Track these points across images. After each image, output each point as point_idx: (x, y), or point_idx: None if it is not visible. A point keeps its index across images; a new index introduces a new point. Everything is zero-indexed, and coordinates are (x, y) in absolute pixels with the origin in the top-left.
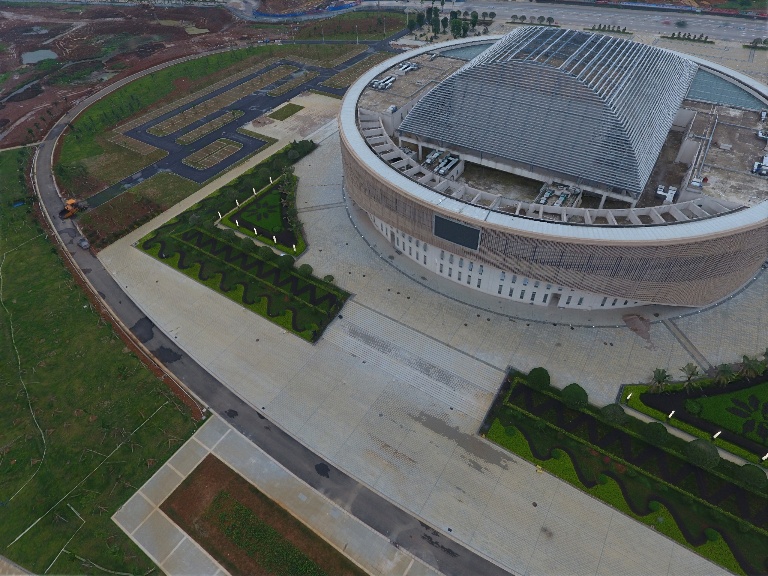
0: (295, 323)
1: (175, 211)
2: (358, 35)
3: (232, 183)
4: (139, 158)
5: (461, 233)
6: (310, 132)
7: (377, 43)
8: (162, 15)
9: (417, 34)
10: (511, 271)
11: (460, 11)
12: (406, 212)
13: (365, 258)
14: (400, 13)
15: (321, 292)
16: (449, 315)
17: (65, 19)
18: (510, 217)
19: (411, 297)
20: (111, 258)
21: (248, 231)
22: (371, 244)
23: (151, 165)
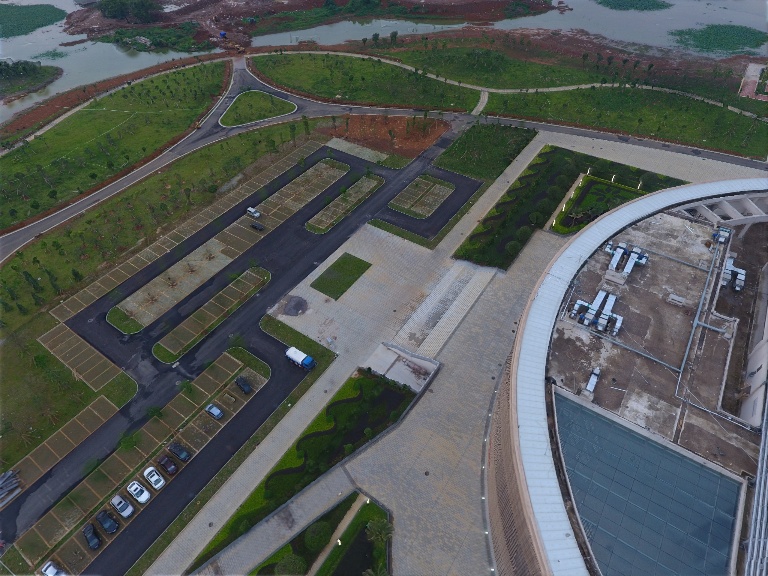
0: None
1: None
2: None
3: None
4: None
5: None
6: None
7: None
8: None
9: None
10: None
11: None
12: None
13: None
14: None
15: None
16: None
17: None
18: None
19: None
20: None
21: None
22: None
23: None
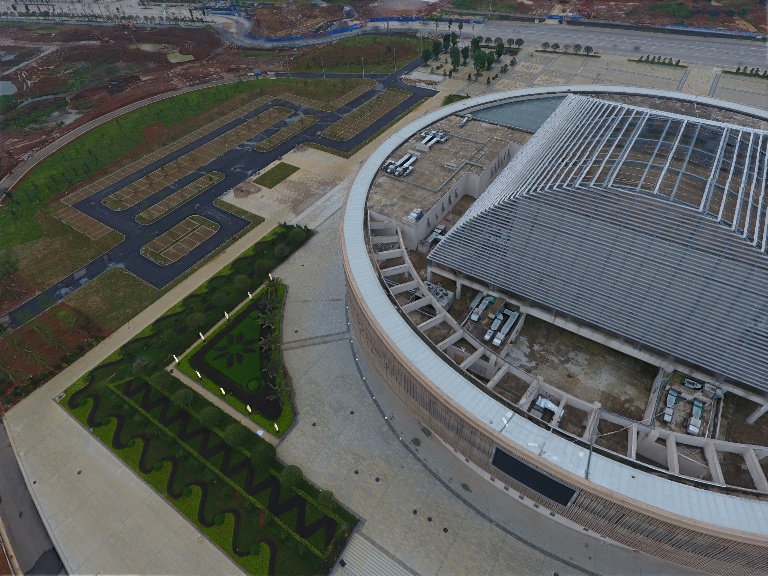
0: (273, 572)
1: (121, 337)
2: (364, 66)
3: (200, 291)
4: (86, 245)
5: (540, 481)
6: (305, 207)
7: (386, 77)
8: (143, 38)
9: (433, 65)
10: (621, 542)
11: (482, 37)
12: (446, 421)
13: (378, 442)
14: (412, 37)
15: (313, 513)
16: (510, 573)
17: (34, 42)
18: (627, 469)
19: (449, 529)
20: (22, 424)
21: (213, 386)
22: (386, 414)
23: (100, 257)
